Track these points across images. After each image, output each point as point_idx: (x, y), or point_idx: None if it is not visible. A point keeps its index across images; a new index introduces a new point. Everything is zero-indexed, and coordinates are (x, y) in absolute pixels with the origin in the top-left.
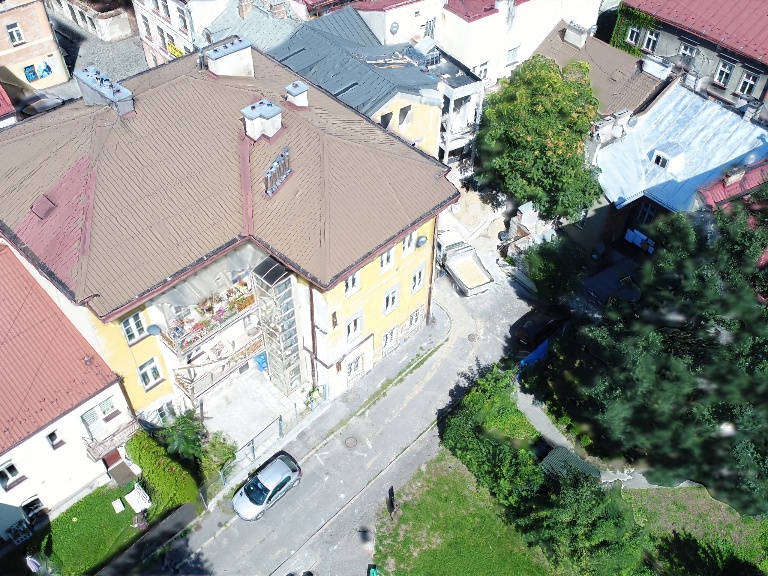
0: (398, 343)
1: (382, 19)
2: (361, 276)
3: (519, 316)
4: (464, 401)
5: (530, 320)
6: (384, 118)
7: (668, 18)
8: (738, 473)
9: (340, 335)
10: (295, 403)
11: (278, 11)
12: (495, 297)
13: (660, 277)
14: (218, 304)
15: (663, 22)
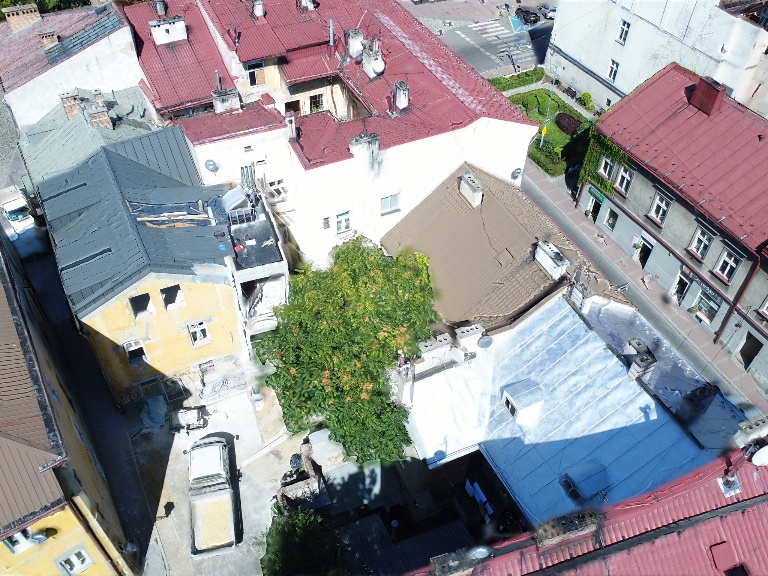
0: None
1: (195, 154)
2: None
3: None
4: None
5: None
6: (138, 299)
7: (643, 158)
8: None
9: None
10: None
11: (98, 120)
12: (241, 560)
13: None
14: None
15: (636, 162)
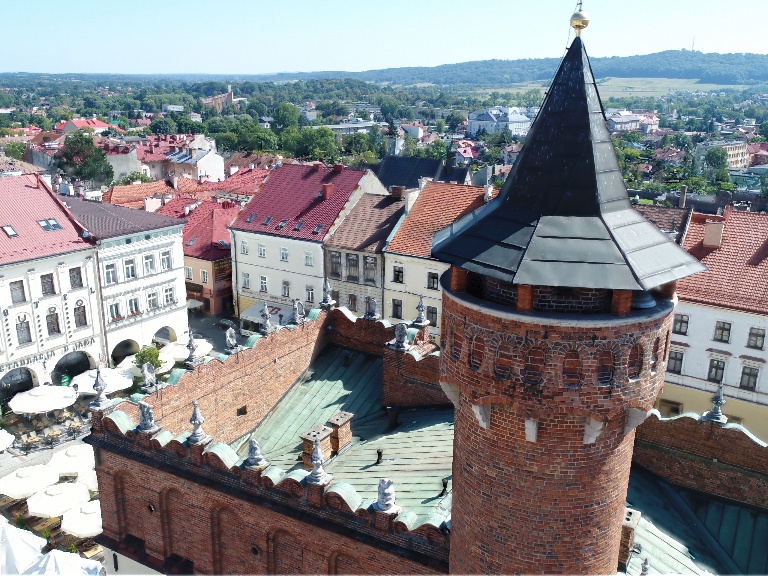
0: None
1: None
2: None
3: None
4: None
5: None
6: None
7: None
8: (107, 172)
9: None
10: None
11: None
12: None
13: None
14: None
15: None
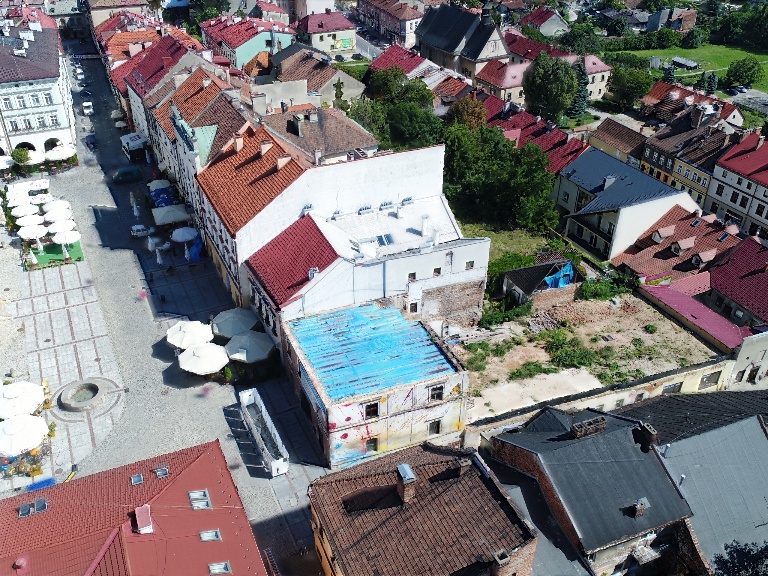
0: None
1: None
2: None
3: None
4: None
5: None
6: None
7: None
8: (222, 1)
9: None
10: None
11: None
12: None
13: None
14: None
15: None
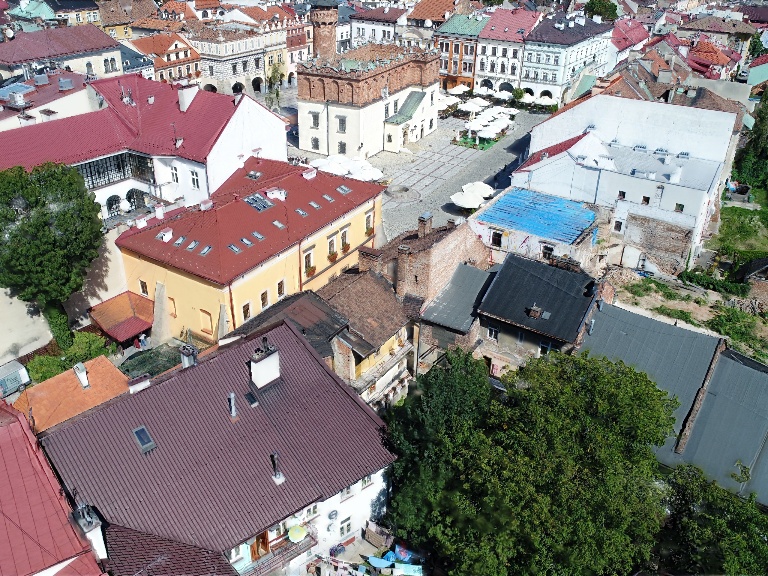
0: None
1: None
2: None
3: None
4: None
5: None
6: None
7: None
8: None
9: None
10: None
11: None
12: None
13: None
14: None
15: None
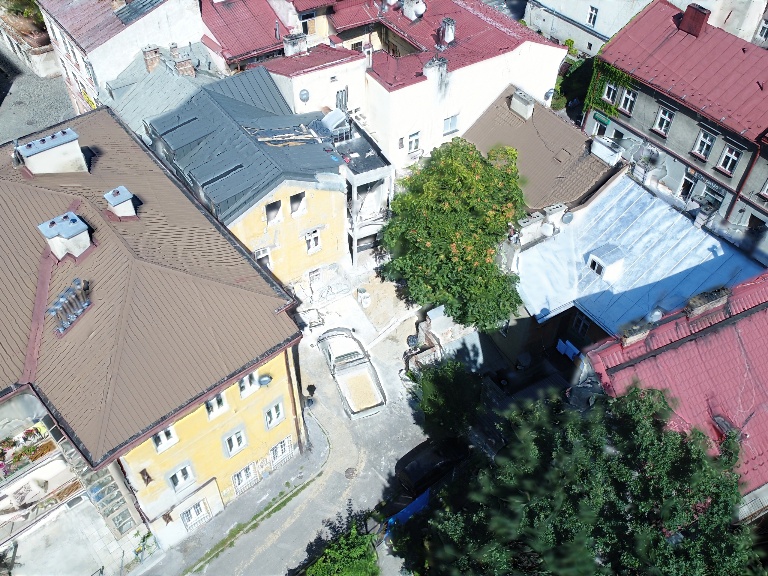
0: (259, 478)
1: (290, 85)
2: (176, 428)
3: (410, 447)
4: (307, 574)
5: (415, 460)
6: (271, 207)
7: (646, 78)
8: None
9: (160, 488)
10: (124, 551)
11: (184, 68)
12: (388, 420)
13: (501, 490)
14: (11, 449)
15: (640, 82)
